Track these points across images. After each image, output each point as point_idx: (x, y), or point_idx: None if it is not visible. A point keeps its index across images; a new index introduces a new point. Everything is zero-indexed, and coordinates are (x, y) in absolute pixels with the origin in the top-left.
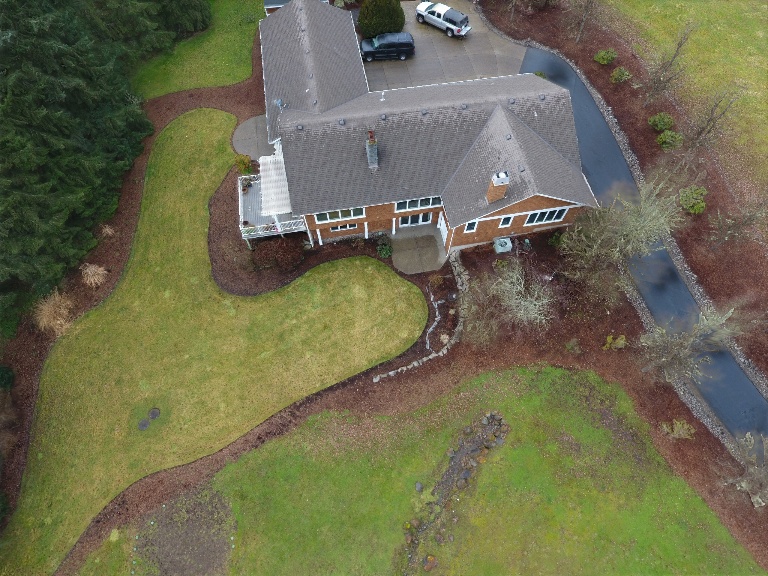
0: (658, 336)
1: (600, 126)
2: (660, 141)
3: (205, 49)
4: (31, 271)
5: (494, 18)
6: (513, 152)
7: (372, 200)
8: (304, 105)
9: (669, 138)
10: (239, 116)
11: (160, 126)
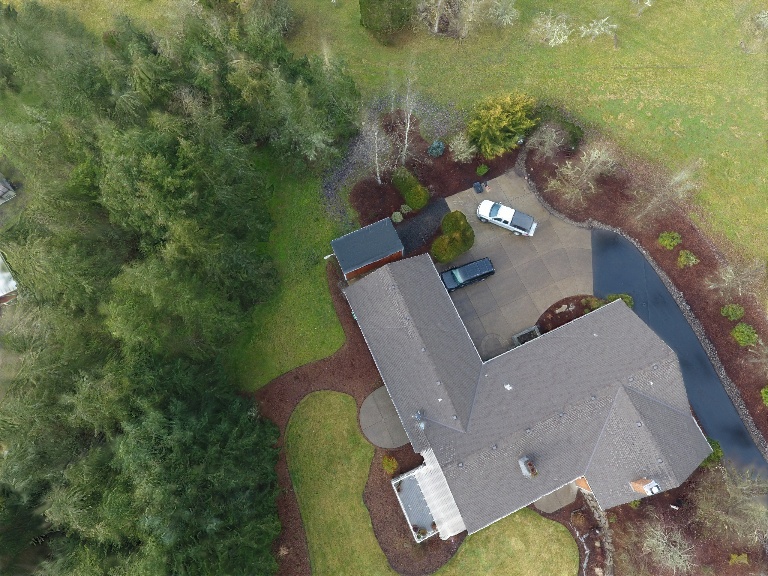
0: None
1: (677, 318)
2: (737, 339)
3: (285, 312)
4: None
5: (551, 198)
6: (647, 441)
7: (530, 499)
8: (443, 417)
9: (746, 338)
10: (355, 395)
11: (282, 423)
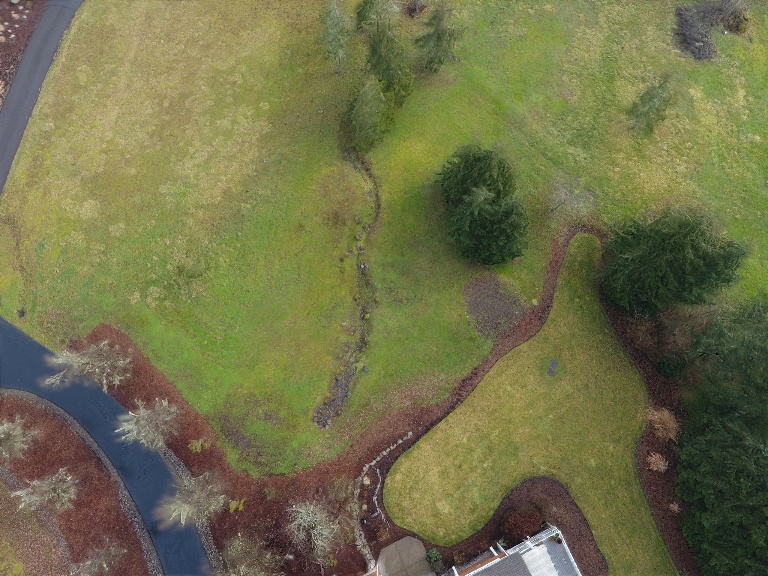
0: (213, 504)
1: None
2: None
3: None
4: (697, 446)
5: None
6: None
7: None
8: None
9: None
10: None
11: None
